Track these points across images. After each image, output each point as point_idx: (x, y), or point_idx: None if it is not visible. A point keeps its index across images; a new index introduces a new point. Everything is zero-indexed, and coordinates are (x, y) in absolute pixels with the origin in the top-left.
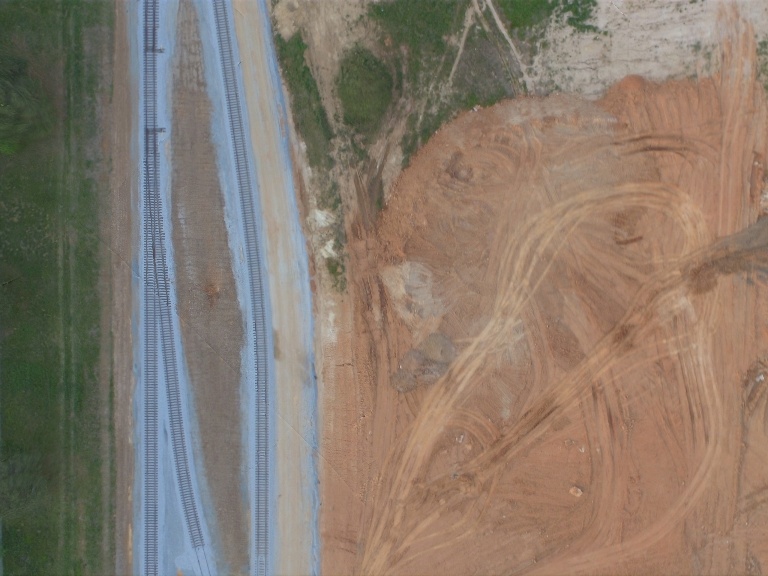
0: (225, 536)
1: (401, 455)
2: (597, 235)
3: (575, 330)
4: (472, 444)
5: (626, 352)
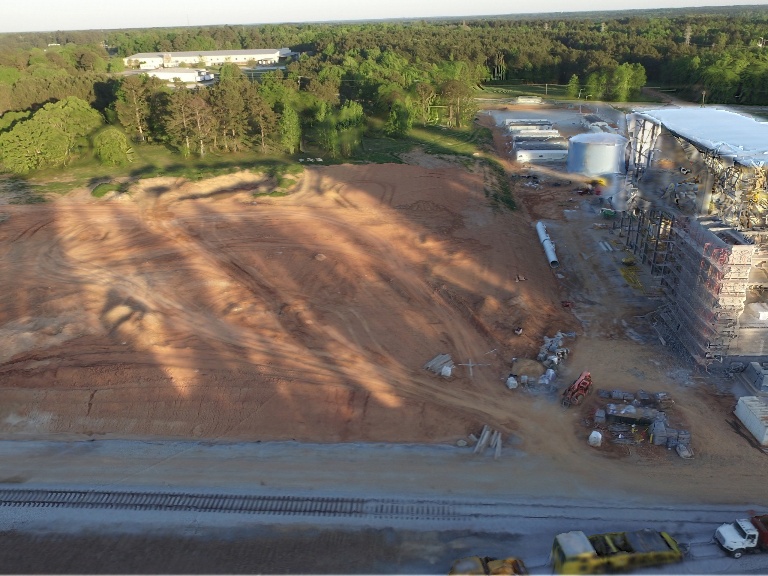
0: (319, 569)
1: (239, 347)
2: (85, 246)
3: (163, 254)
4: (248, 303)
5: (200, 237)
